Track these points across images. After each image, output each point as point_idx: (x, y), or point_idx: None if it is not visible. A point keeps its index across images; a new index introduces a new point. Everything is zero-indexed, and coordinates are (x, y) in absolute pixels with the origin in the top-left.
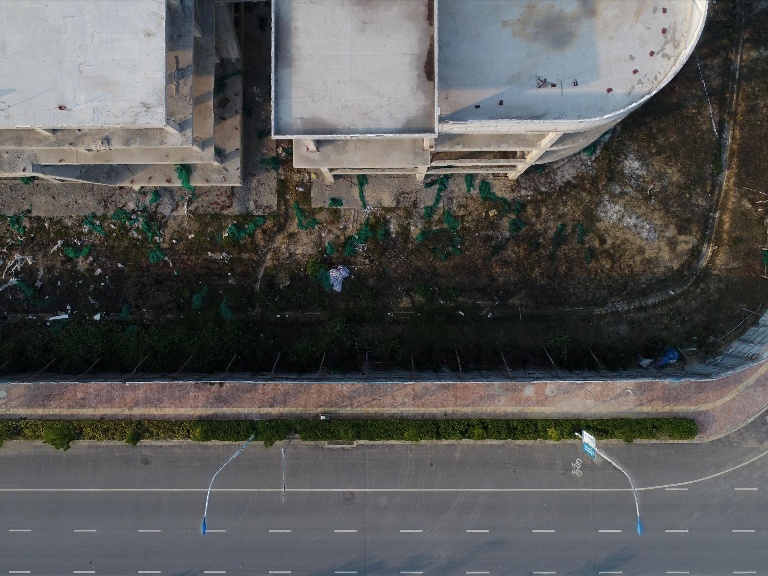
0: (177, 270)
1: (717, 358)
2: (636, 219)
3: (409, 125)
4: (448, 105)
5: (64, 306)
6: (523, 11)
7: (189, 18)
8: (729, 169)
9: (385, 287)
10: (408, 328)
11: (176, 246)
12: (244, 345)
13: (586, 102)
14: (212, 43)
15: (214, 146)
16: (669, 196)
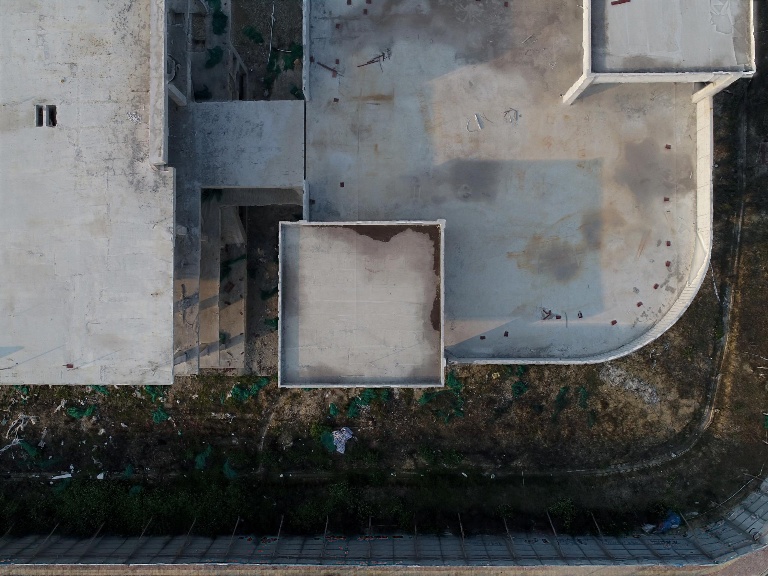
0: (180, 430)
1: (719, 522)
2: (638, 383)
3: (415, 374)
4: (453, 336)
5: (67, 466)
6: (528, 242)
7: (196, 246)
8: (731, 332)
9: (388, 449)
10: (411, 491)
11: (180, 406)
12: (247, 509)
13: (591, 334)
14: (218, 245)
15: (219, 331)
16: (671, 360)
